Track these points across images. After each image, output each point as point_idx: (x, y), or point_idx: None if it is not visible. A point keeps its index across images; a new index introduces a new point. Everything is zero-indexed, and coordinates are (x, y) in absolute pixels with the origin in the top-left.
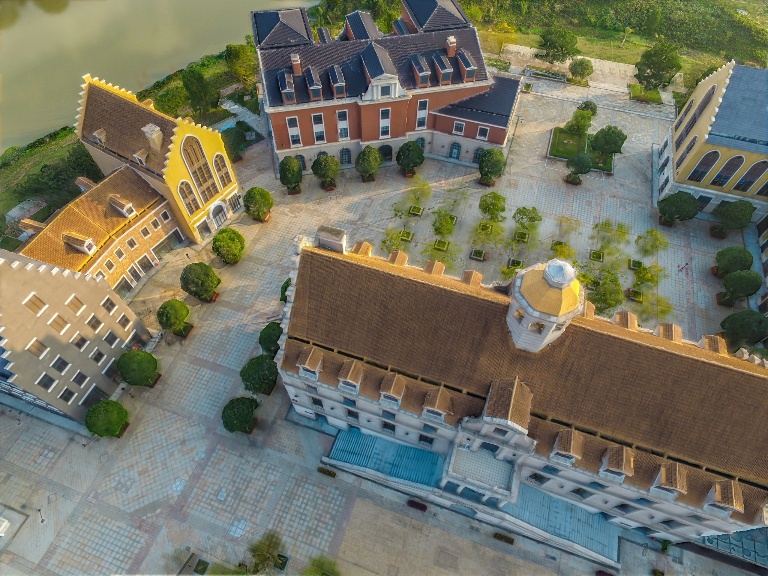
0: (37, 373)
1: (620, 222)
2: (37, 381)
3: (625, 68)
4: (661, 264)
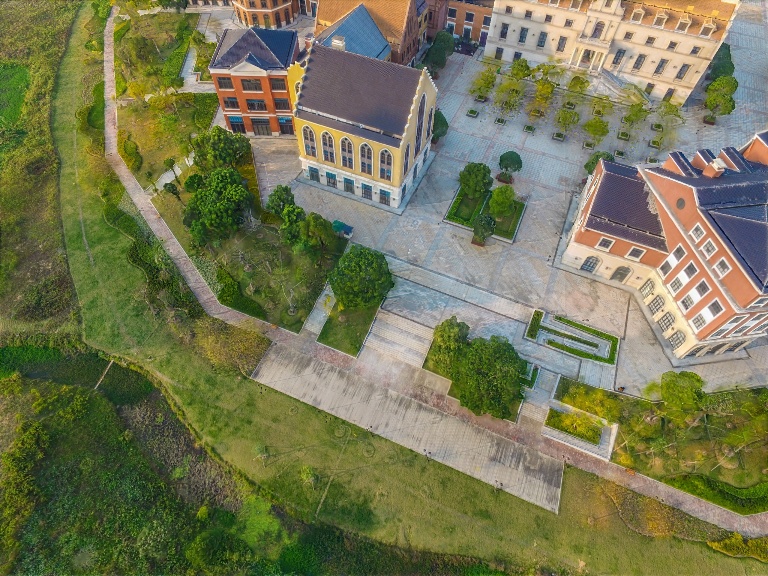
0: None
1: (472, 143)
2: None
3: (341, 400)
4: (453, 114)
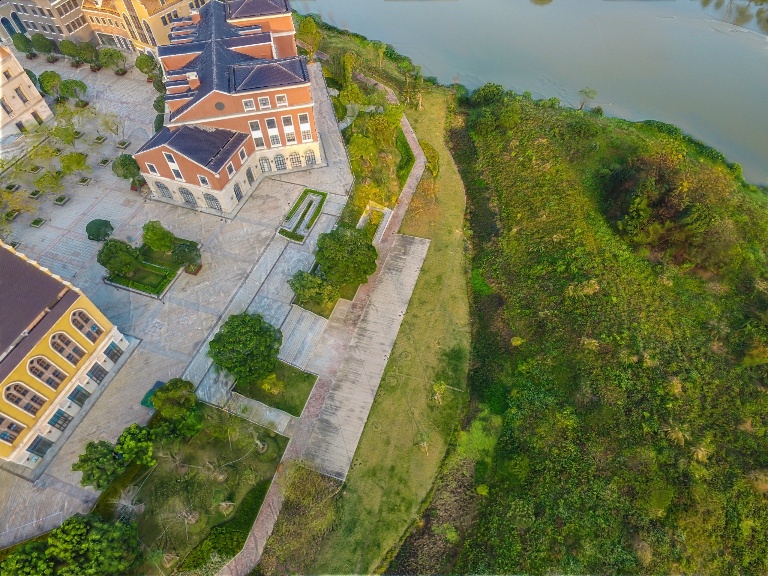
0: (13, 0)
1: None
2: (13, 3)
3: (363, 383)
4: None
